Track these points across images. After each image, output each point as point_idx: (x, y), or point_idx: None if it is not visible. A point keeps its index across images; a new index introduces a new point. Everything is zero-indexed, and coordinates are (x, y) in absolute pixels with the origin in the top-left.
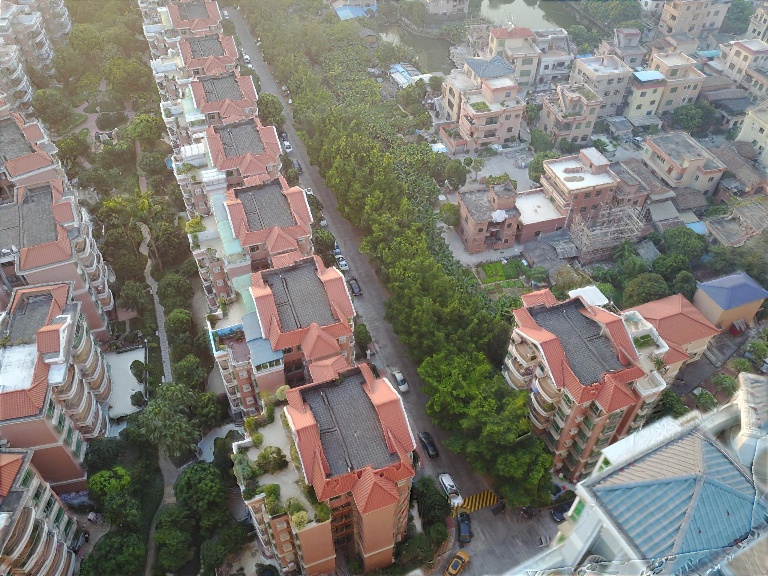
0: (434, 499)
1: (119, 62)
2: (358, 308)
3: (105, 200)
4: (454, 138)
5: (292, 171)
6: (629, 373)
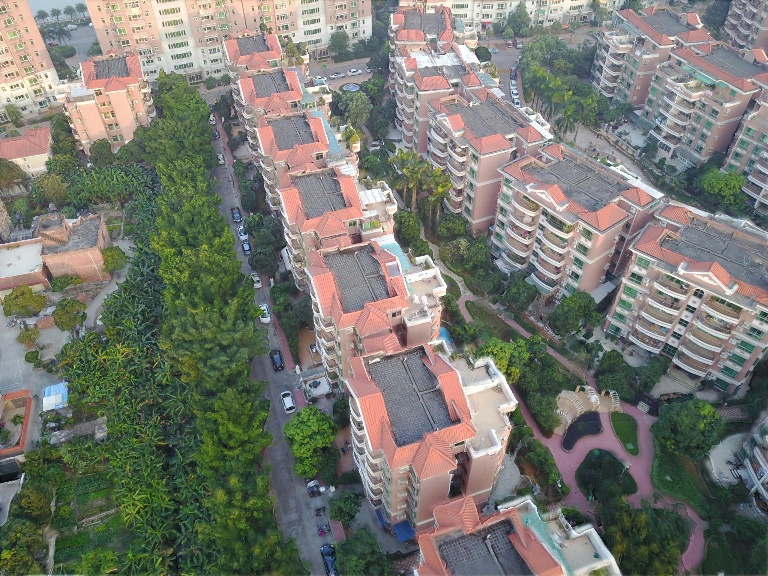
0: (221, 102)
1: (661, 570)
2: (237, 202)
3: (493, 274)
4: (9, 440)
5: (279, 306)
6: (98, 58)
